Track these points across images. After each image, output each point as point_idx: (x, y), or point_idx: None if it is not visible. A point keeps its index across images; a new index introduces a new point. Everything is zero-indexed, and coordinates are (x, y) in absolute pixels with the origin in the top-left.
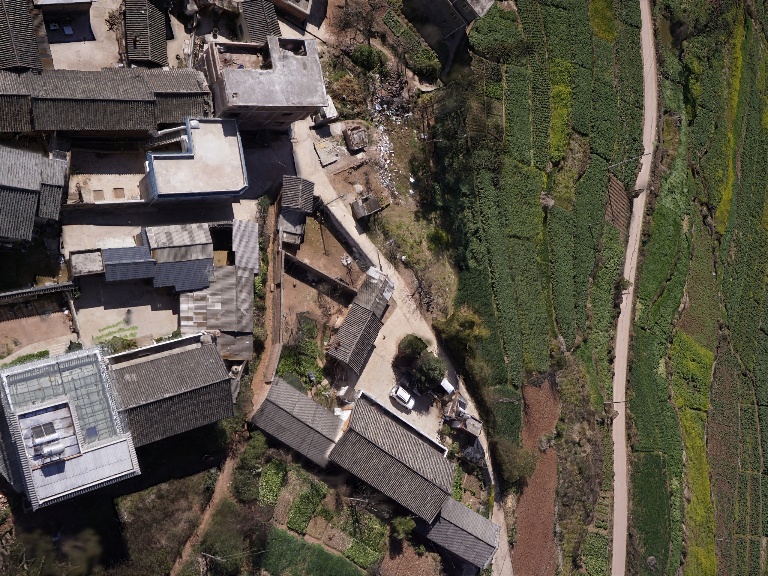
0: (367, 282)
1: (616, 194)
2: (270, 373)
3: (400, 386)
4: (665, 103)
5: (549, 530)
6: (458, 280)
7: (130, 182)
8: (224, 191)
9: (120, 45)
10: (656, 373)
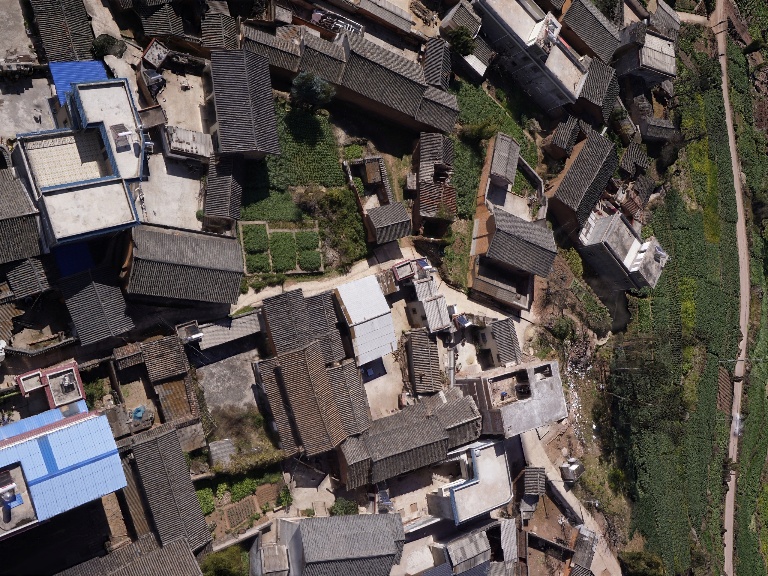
0: (581, 540)
1: (723, 382)
2: None
3: None
4: (751, 279)
5: None
6: (631, 510)
7: (420, 496)
8: (500, 505)
9: (404, 374)
10: (749, 530)
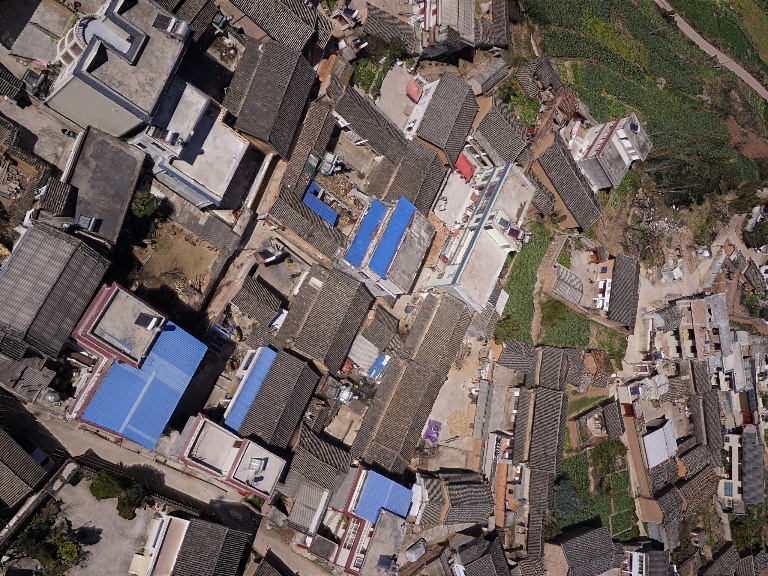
0: (735, 262)
1: None
2: (762, 324)
3: (760, 248)
4: None
5: (767, 148)
6: None
7: None
8: None
9: None
10: None
